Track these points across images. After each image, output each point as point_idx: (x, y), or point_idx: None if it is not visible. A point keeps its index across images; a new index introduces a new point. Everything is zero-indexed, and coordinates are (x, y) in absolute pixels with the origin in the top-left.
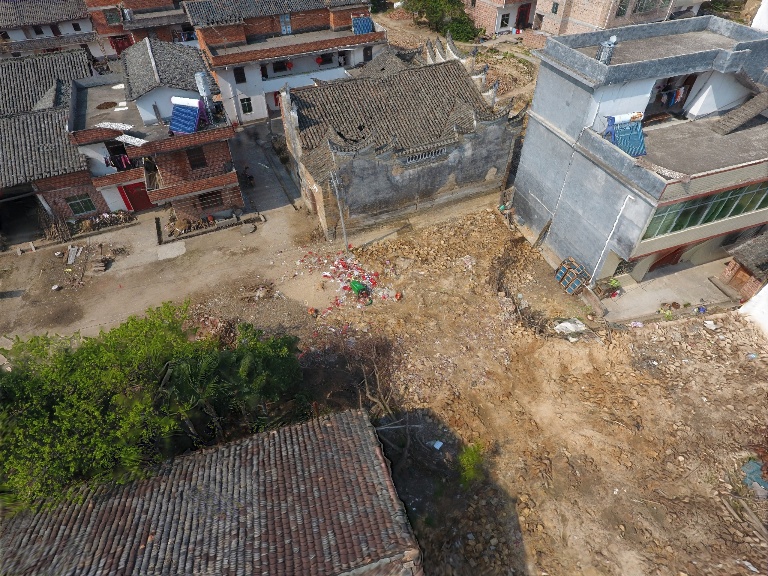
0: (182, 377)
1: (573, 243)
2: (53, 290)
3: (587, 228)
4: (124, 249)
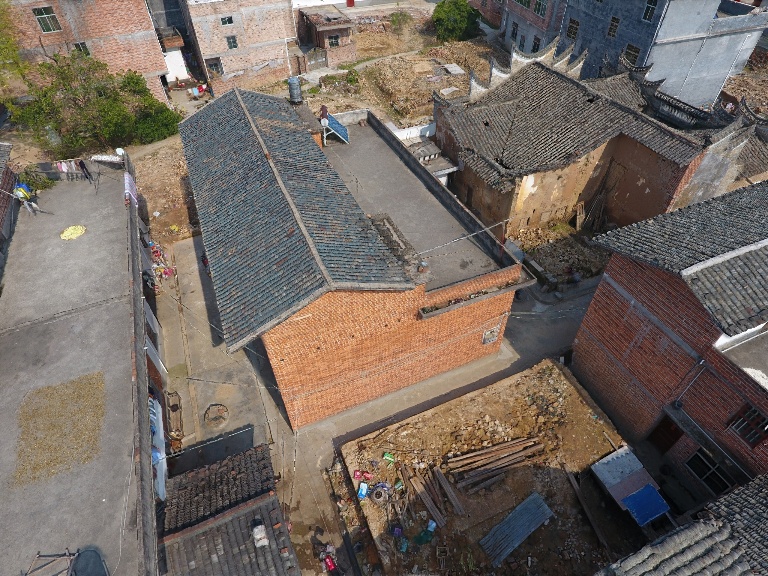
0: None
1: (697, 98)
2: None
3: (711, 79)
4: None
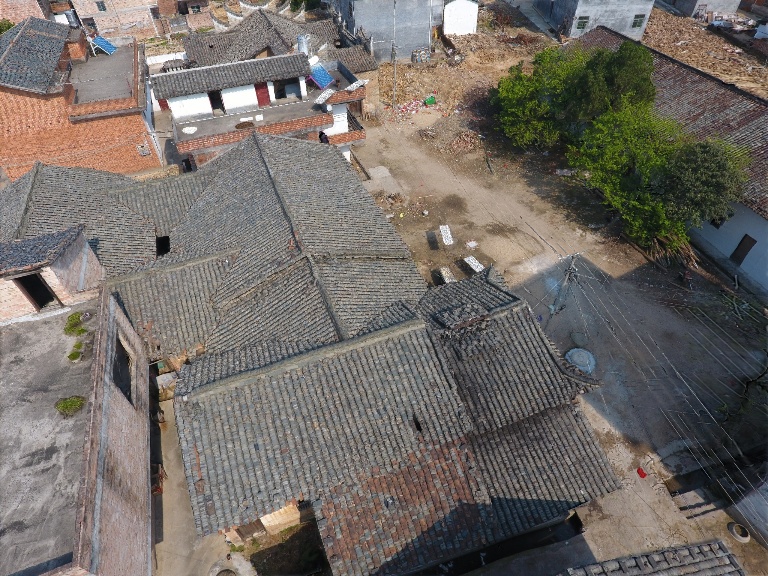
0: (560, 54)
1: (412, 43)
2: (426, 216)
3: (417, 28)
4: (375, 194)
